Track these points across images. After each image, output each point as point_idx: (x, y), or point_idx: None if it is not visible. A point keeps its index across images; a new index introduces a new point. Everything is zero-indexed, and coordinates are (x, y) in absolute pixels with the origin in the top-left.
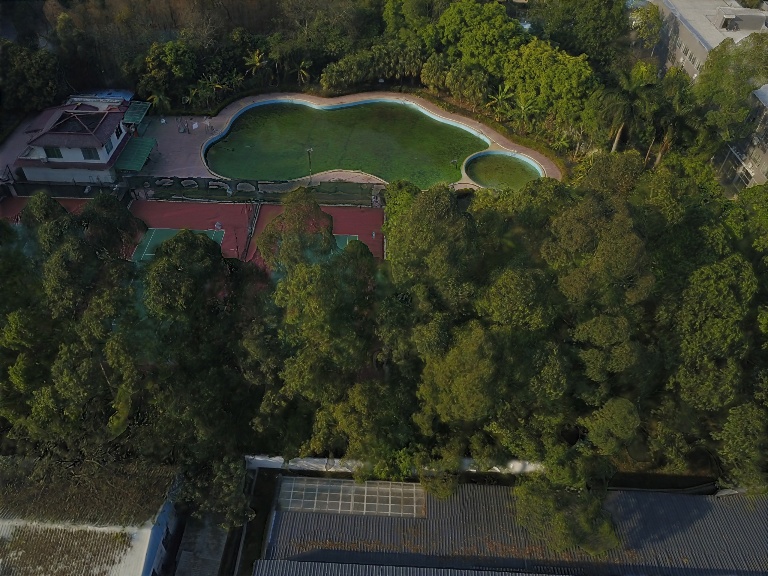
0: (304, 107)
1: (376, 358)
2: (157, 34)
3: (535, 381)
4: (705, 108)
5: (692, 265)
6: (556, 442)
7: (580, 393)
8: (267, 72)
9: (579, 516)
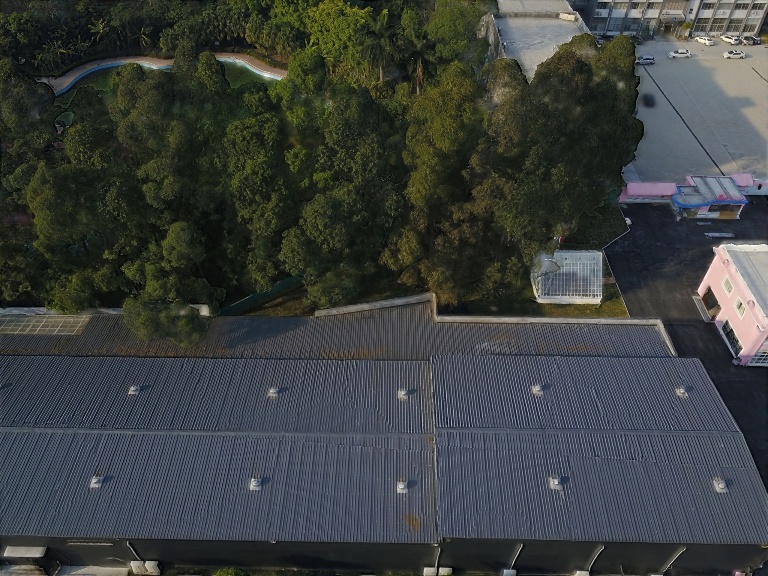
0: (144, 68)
1: (32, 212)
2: (9, 7)
3: (100, 204)
4: (435, 42)
5: (230, 121)
6: (152, 263)
7: (149, 218)
8: (112, 38)
9: (162, 314)
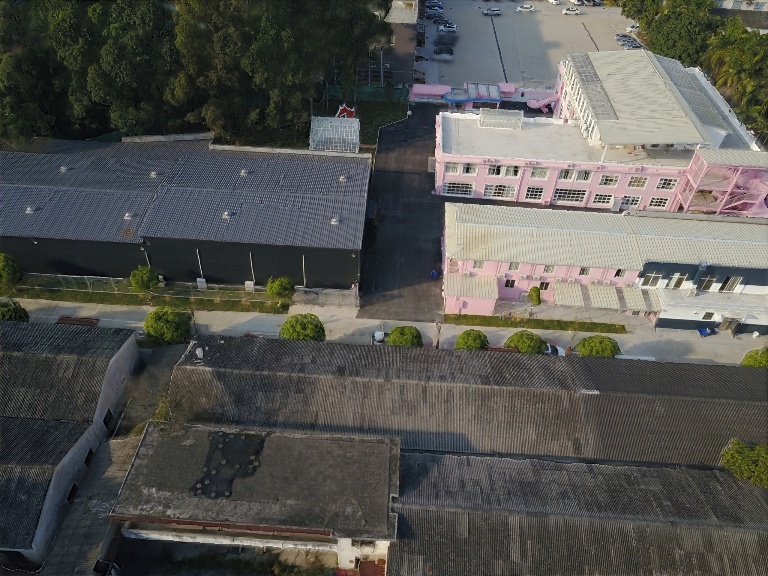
0: None
1: None
2: None
3: None
4: None
5: None
6: None
7: None
8: None
9: None
